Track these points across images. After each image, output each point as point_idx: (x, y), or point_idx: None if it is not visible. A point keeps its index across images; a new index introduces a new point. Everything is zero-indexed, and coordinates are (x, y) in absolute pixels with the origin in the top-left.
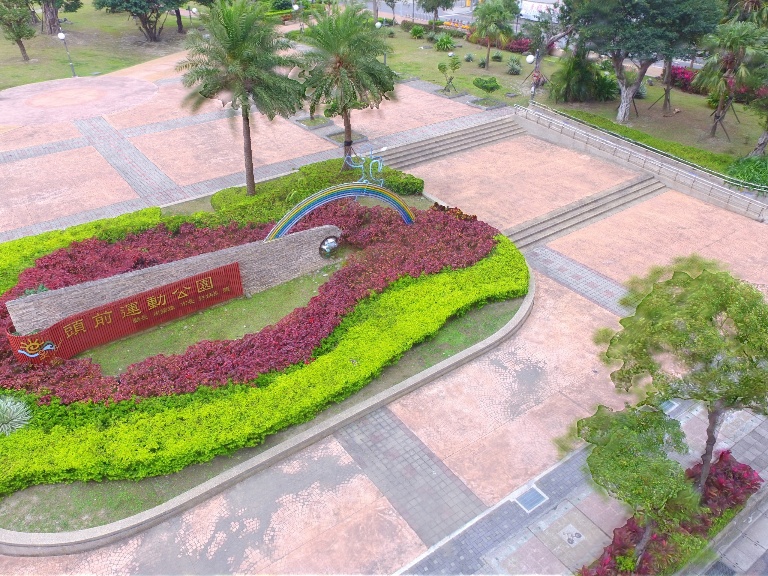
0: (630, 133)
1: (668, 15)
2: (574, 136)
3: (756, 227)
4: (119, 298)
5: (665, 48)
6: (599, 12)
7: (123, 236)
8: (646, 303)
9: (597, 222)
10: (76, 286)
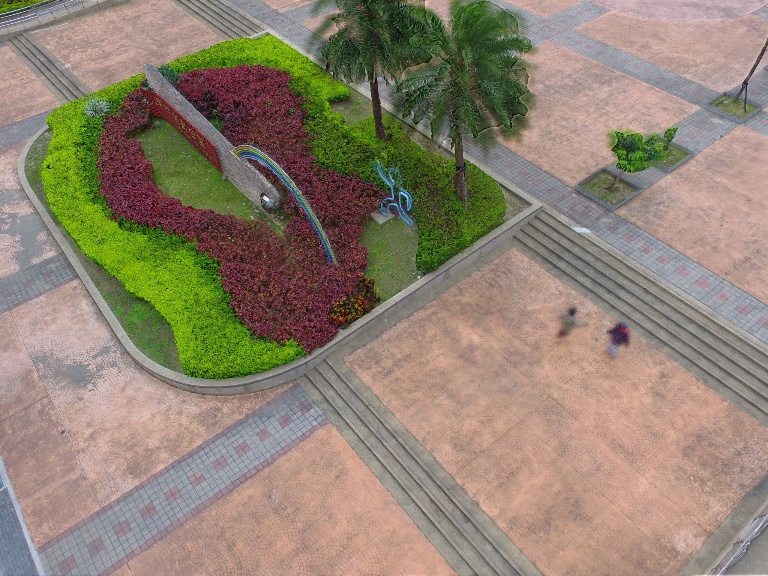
0: None
1: None
2: None
3: None
4: None
5: None
6: None
7: None
8: None
9: (403, 510)
10: (165, 80)
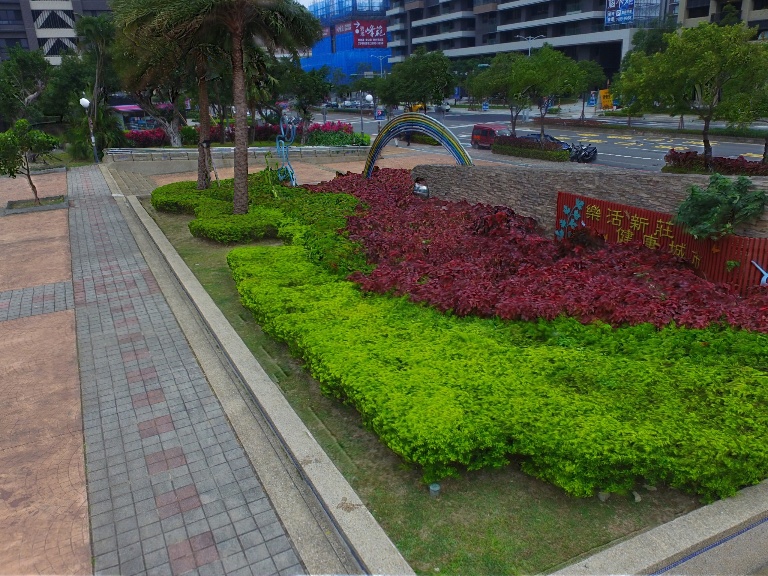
0: None
1: None
2: None
3: None
4: None
5: None
6: None
7: None
8: (693, 50)
9: None
10: None
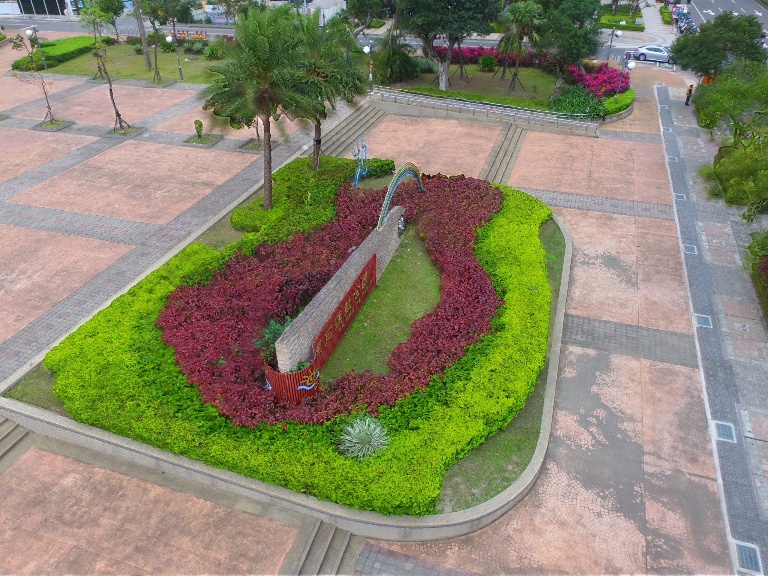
0: (471, 97)
1: (473, 1)
2: (434, 107)
3: (599, 141)
4: (330, 311)
5: (479, 26)
6: (421, 3)
7: (208, 276)
8: (754, 163)
9: (516, 162)
10: (308, 309)
